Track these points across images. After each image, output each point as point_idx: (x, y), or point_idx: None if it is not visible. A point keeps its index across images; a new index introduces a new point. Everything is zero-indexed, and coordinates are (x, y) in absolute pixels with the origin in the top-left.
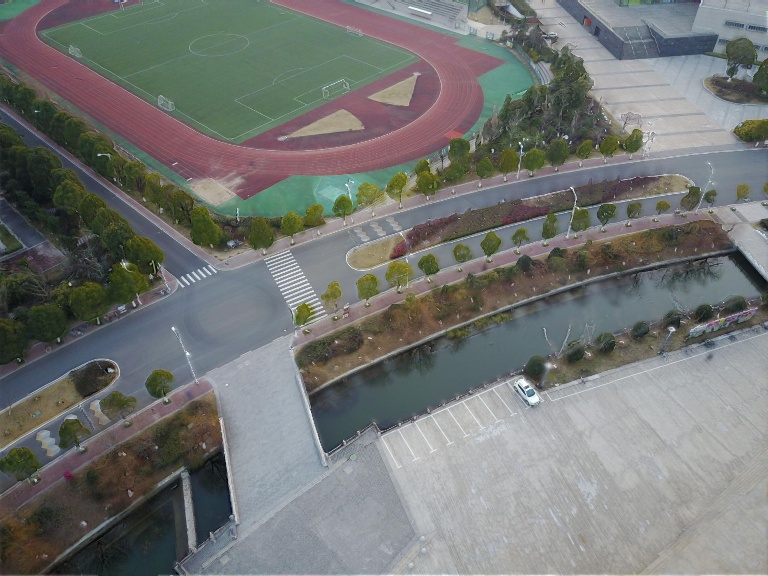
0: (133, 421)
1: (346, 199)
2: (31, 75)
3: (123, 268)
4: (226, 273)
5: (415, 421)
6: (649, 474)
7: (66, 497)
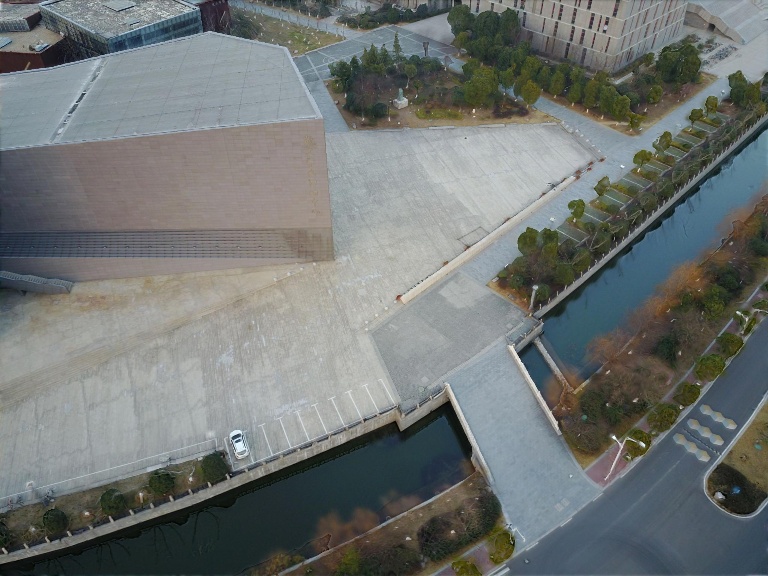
0: None
1: None
2: None
3: None
4: None
5: None
6: (169, 368)
7: (660, 370)
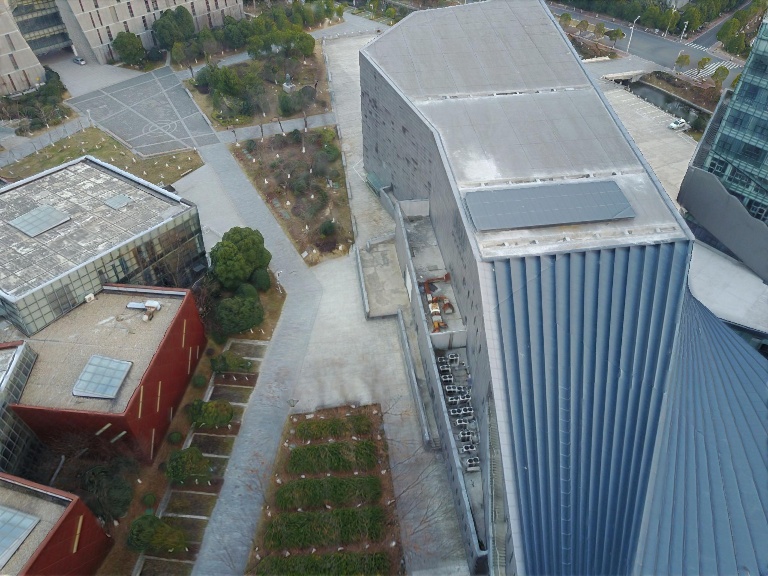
0: None
1: None
2: None
3: (672, 10)
4: (705, 52)
5: (637, 97)
6: (644, 154)
7: None
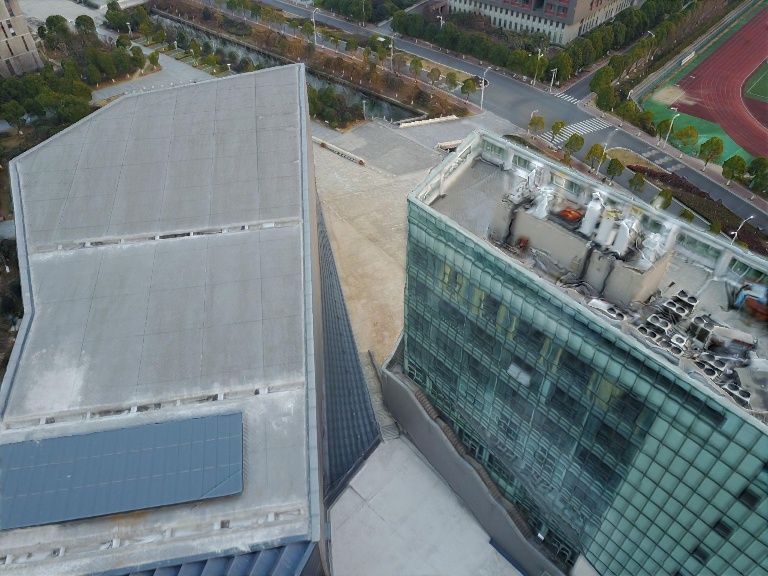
0: (452, 97)
1: (667, 123)
2: (765, 9)
3: (538, 55)
4: (575, 106)
5: None
6: None
7: None
